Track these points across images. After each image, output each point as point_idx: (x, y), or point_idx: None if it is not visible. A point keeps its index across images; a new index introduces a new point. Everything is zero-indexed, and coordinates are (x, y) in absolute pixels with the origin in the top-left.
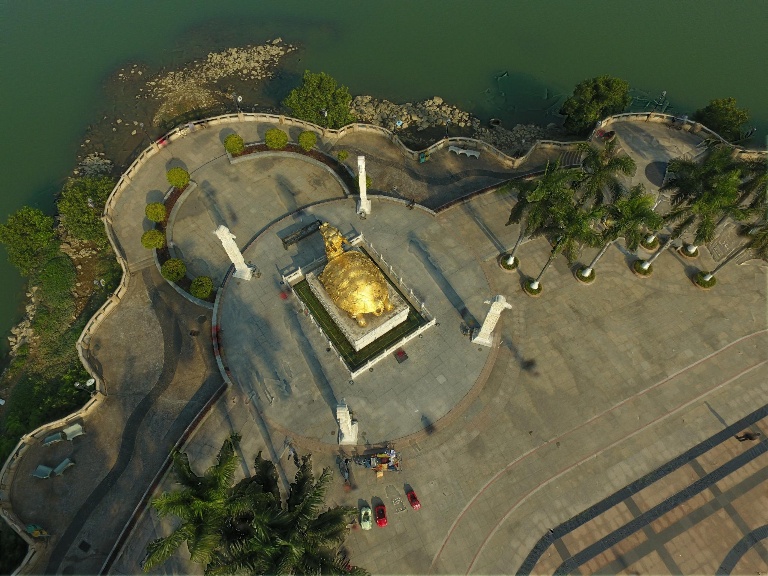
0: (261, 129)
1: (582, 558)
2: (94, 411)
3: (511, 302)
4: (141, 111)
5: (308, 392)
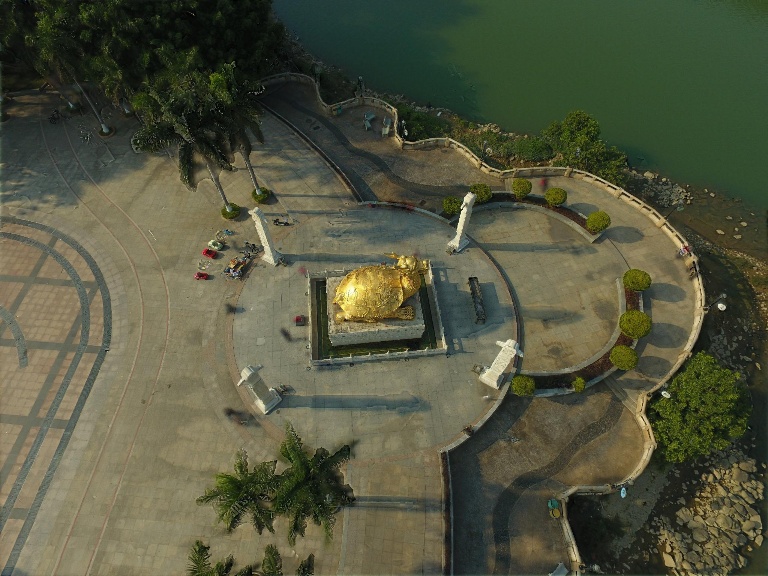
0: (675, 330)
1: (76, 359)
2: (396, 143)
3: (284, 463)
4: (762, 246)
5: (321, 246)
